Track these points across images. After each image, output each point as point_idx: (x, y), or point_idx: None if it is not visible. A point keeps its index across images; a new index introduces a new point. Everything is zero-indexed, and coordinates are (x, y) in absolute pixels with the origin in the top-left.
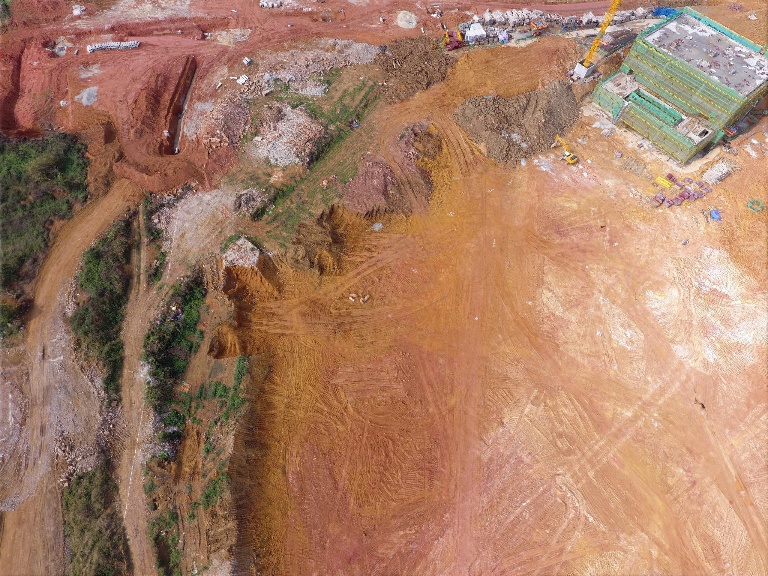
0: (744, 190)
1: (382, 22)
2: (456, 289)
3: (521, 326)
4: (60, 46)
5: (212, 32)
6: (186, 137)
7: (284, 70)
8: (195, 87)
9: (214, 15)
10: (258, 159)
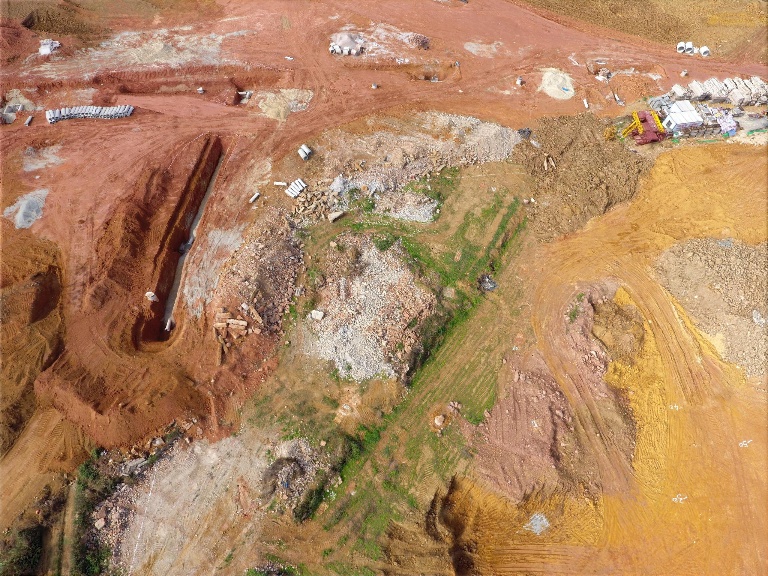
0: None
1: (519, 86)
2: None
3: None
4: (12, 104)
5: (252, 90)
6: (185, 309)
7: (367, 173)
8: (214, 197)
9: (257, 64)
10: (314, 362)
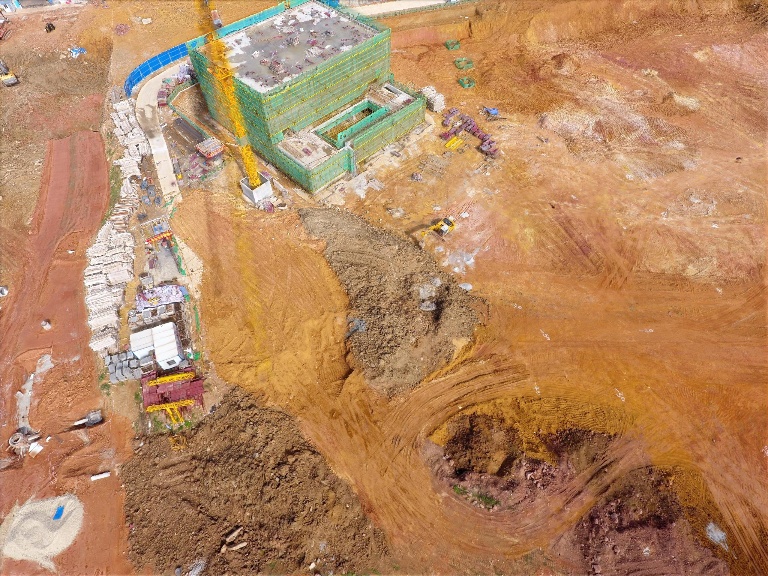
0: (444, 86)
1: None
2: (760, 384)
3: (761, 302)
4: None
5: None
6: None
7: None
8: None
9: None
10: None
